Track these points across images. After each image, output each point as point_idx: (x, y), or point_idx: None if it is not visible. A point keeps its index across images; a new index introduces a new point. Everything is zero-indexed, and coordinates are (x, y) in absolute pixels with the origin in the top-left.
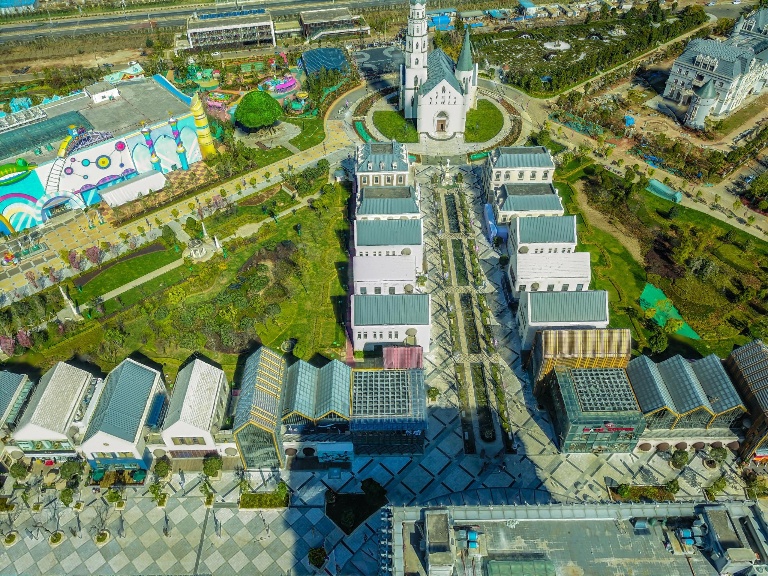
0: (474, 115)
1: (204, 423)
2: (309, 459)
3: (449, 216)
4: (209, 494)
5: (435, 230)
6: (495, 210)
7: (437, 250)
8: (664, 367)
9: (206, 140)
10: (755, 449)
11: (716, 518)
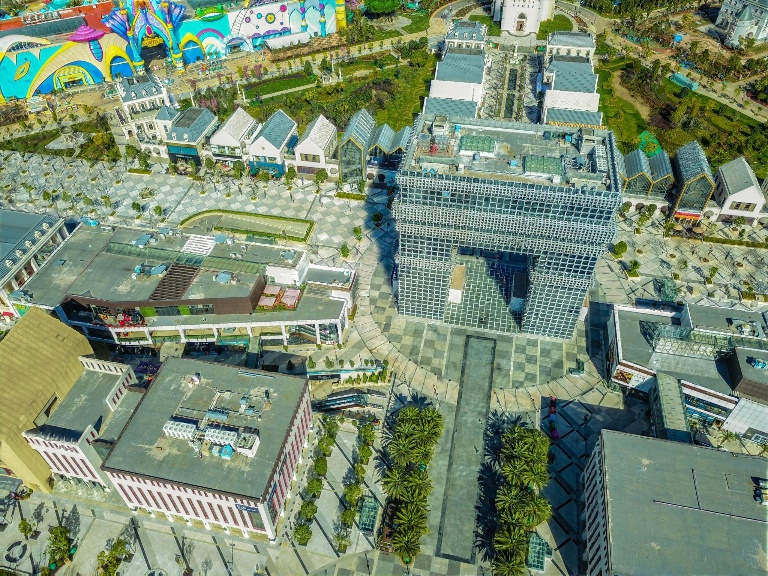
0: (550, 23)
1: (321, 146)
2: (381, 184)
3: (510, 81)
4: (318, 189)
5: (497, 87)
6: (543, 75)
7: (495, 98)
8: (628, 156)
9: (341, 16)
10: (676, 208)
11: (586, 132)
